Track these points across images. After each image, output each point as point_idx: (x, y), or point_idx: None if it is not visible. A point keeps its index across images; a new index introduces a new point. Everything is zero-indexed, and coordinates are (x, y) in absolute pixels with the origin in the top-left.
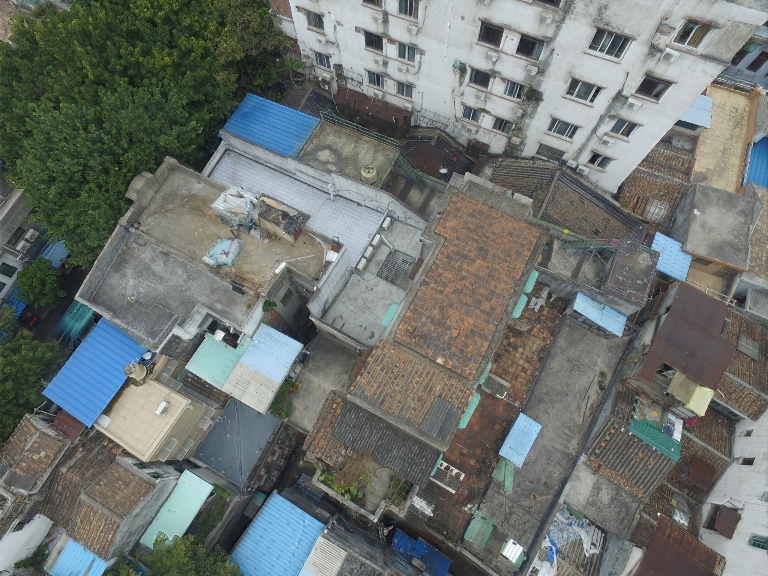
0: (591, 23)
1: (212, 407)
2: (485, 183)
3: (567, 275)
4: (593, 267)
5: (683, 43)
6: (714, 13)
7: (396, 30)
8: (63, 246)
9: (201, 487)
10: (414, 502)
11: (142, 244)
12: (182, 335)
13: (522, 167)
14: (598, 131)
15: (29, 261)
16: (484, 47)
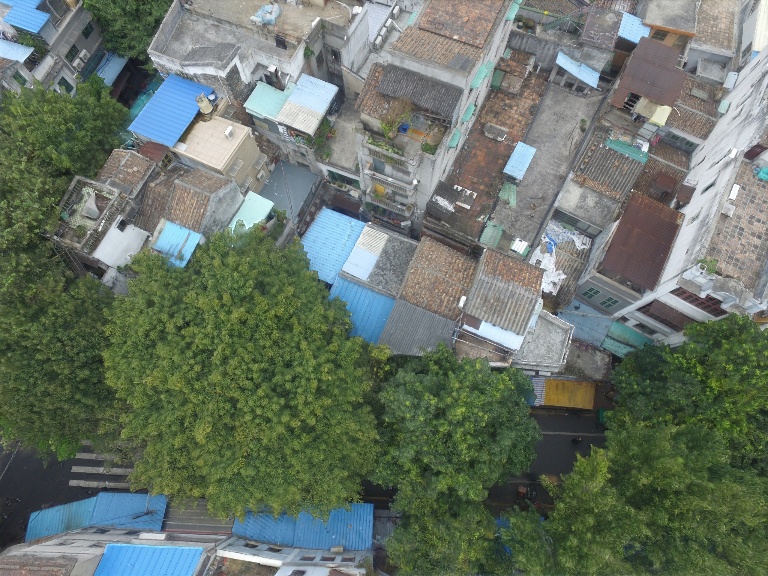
0: None
1: (264, 154)
2: None
3: (549, 38)
4: None
5: None
6: None
7: None
8: (110, 72)
9: (264, 203)
10: (439, 201)
11: (195, 20)
12: (241, 73)
13: None
14: None
15: (82, 82)
16: None
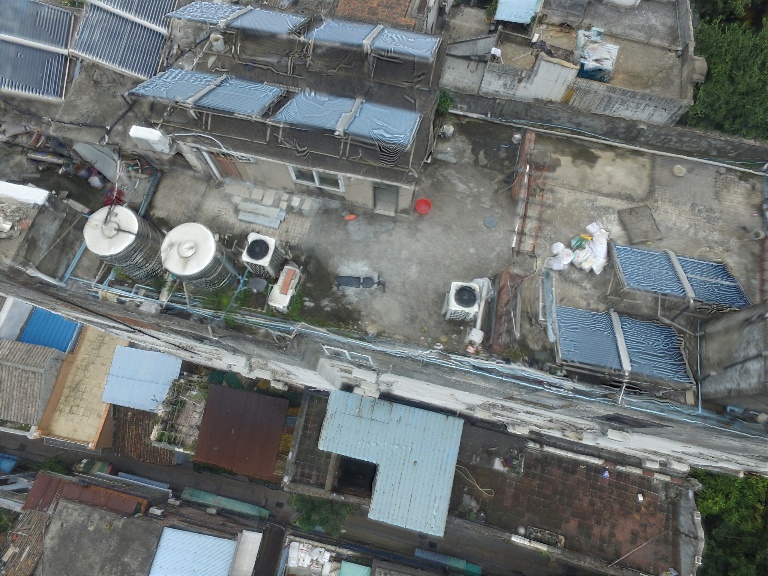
0: None
1: None
2: None
3: None
4: None
5: None
6: None
7: None
8: None
9: None
10: None
11: None
12: None
13: None
14: None
15: None
16: None
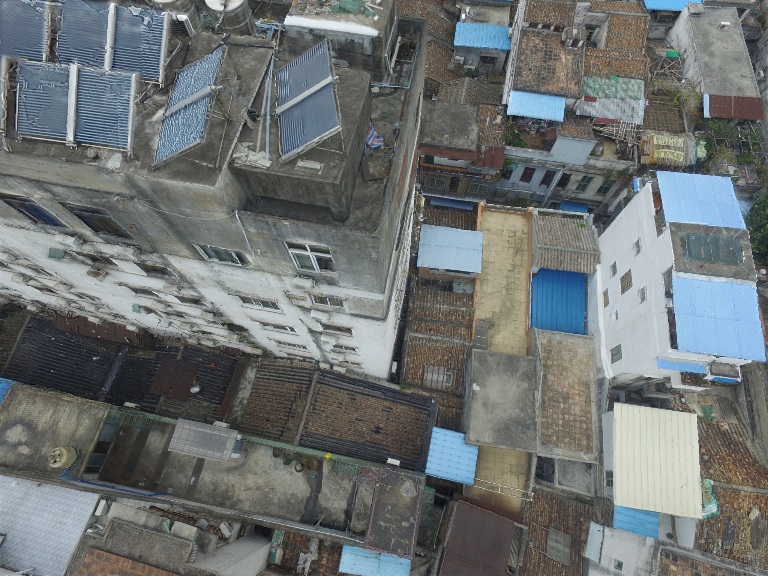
0: (222, 290)
1: None
2: (136, 514)
3: None
4: (371, 487)
5: (327, 303)
6: (327, 290)
7: (52, 284)
8: None
9: None
10: None
11: None
12: None
13: (282, 367)
14: (323, 348)
15: None
16: (147, 298)
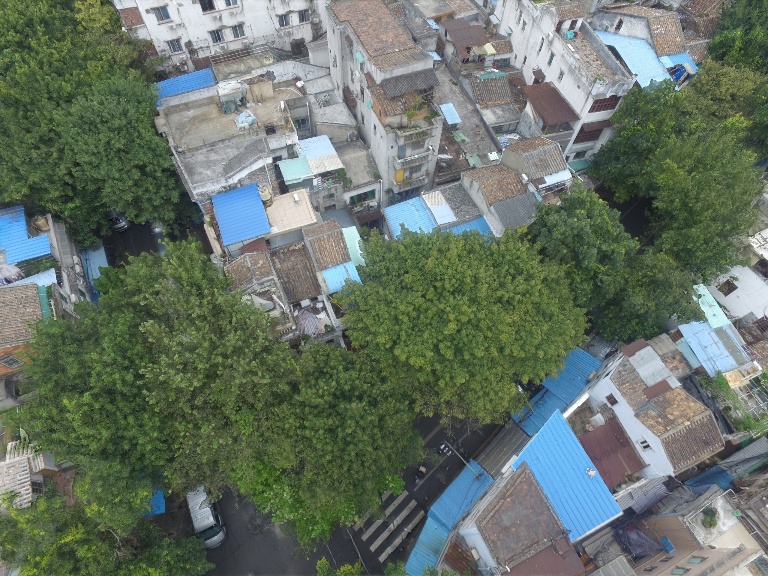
0: None
1: None
2: None
3: None
4: None
5: None
6: None
7: None
8: None
9: (350, 230)
10: (441, 157)
11: (191, 156)
12: None
13: None
14: None
15: None
16: None
